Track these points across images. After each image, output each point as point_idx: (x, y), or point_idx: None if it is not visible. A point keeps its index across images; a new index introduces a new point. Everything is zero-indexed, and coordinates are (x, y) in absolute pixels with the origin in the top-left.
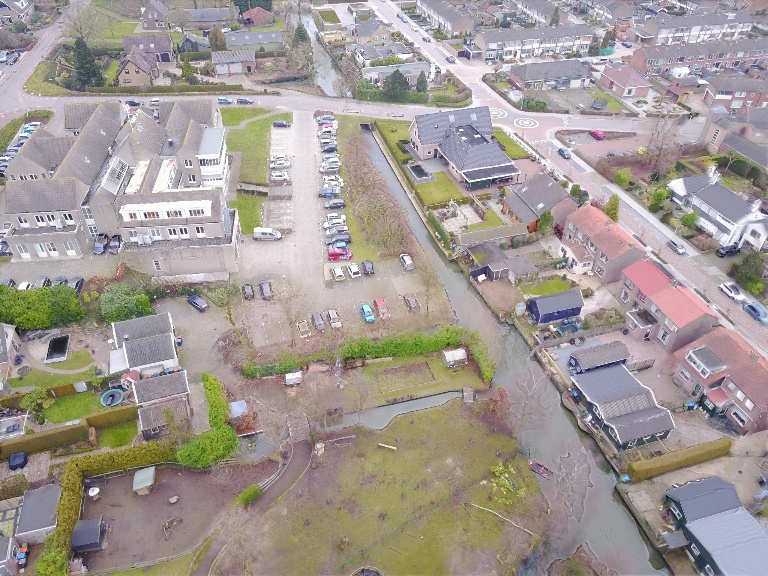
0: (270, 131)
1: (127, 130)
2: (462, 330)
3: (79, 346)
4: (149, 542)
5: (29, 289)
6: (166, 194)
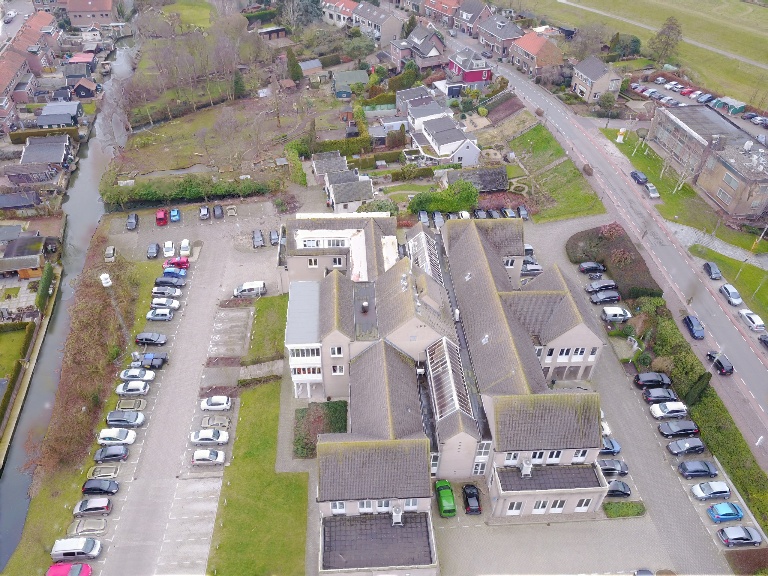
0: (208, 573)
1: (420, 277)
2: (110, 188)
3: (404, 204)
4: (325, 135)
5: (451, 199)
6: (344, 218)
